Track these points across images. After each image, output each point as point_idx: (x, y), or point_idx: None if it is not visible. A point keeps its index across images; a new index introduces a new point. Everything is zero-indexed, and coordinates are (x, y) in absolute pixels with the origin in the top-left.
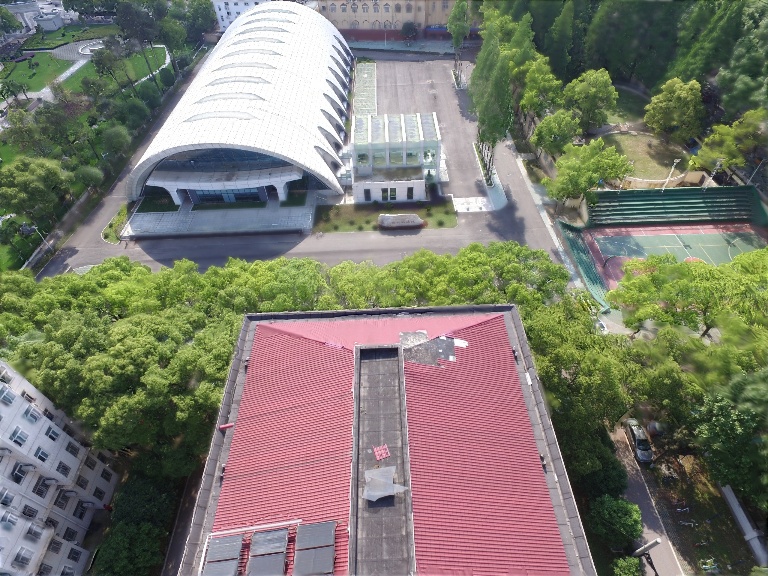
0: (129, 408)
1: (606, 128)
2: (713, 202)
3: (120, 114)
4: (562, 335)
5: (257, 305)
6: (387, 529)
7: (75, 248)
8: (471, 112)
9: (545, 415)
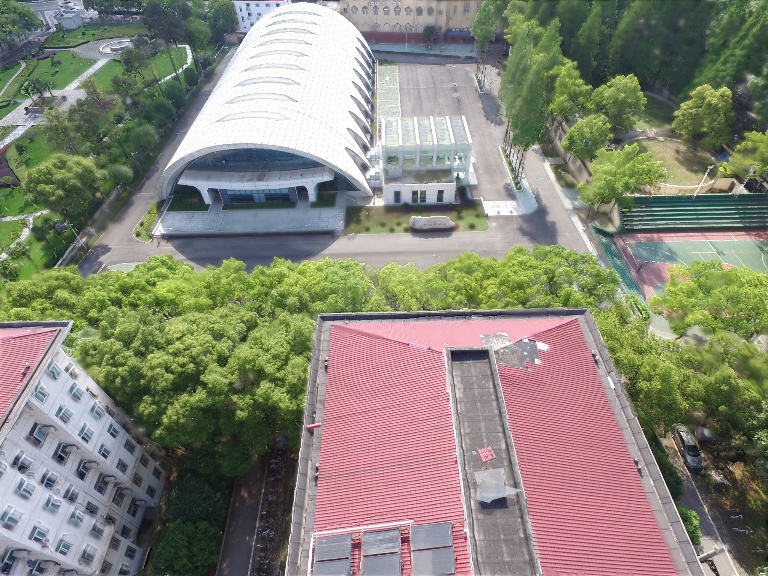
0: (191, 406)
1: (632, 133)
2: (745, 209)
3: (145, 113)
4: (619, 340)
5: (308, 305)
6: (504, 531)
7: (108, 246)
8: (495, 116)
9: (633, 419)
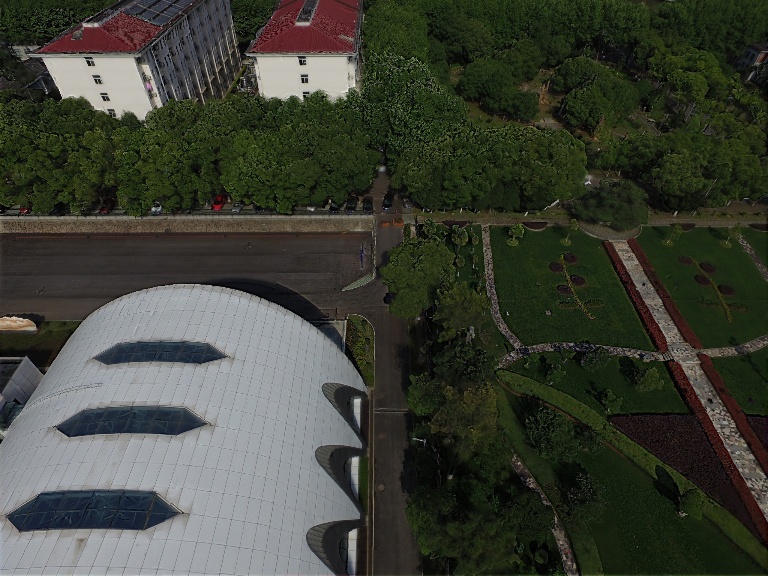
0: None
1: None
2: None
3: None
4: None
5: None
6: None
7: None
8: None
9: None
